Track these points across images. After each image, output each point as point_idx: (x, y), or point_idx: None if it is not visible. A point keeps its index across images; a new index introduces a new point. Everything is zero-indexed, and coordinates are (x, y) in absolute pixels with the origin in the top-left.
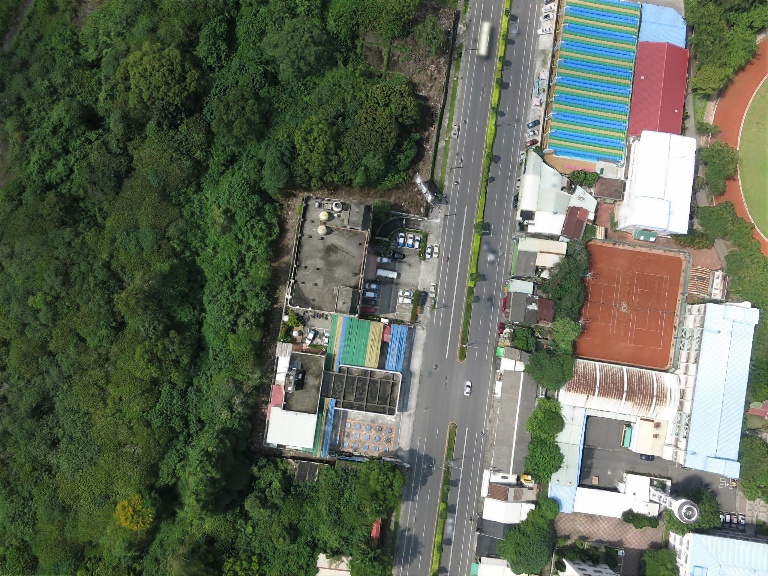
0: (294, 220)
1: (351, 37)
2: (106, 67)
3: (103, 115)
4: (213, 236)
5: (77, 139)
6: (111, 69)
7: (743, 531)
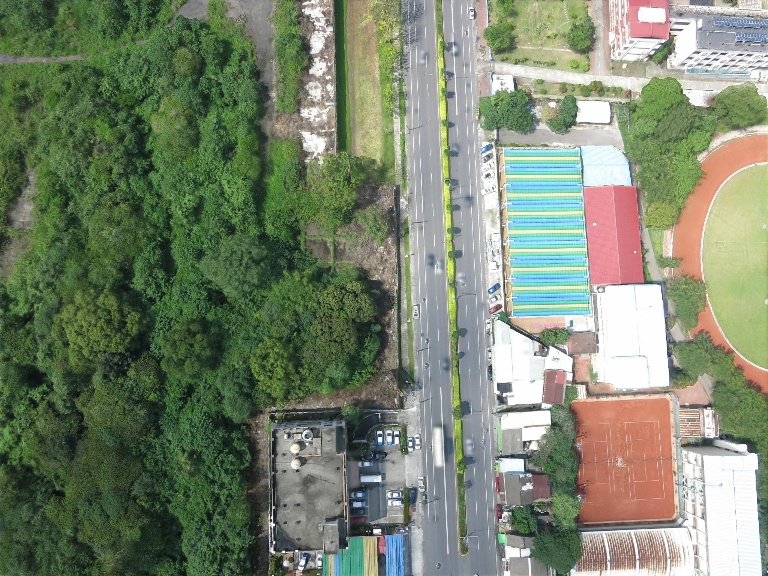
0: (265, 439)
1: (292, 235)
2: (39, 327)
3: (44, 372)
4: (182, 480)
5: (20, 404)
6: (45, 328)
7: None
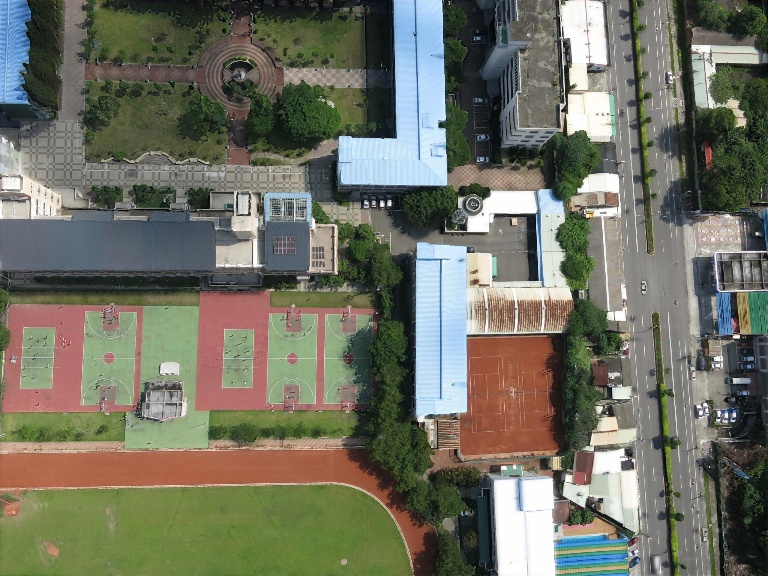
0: None
1: None
2: None
3: None
4: None
5: None
6: None
7: (363, 194)
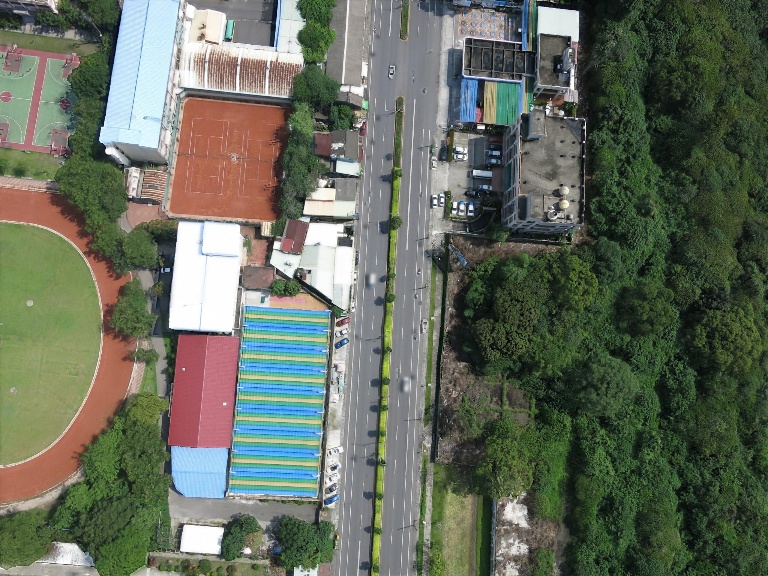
0: None
1: (544, 414)
2: None
3: (767, 300)
4: None
5: None
6: None
7: None
